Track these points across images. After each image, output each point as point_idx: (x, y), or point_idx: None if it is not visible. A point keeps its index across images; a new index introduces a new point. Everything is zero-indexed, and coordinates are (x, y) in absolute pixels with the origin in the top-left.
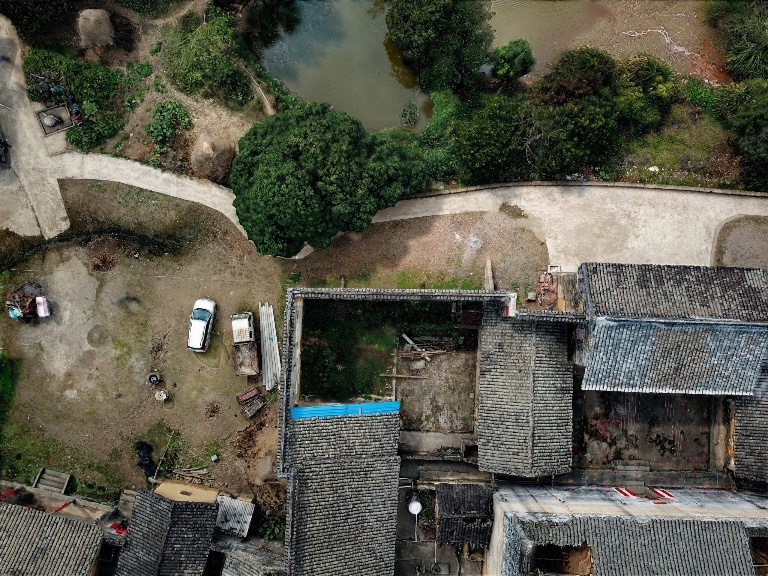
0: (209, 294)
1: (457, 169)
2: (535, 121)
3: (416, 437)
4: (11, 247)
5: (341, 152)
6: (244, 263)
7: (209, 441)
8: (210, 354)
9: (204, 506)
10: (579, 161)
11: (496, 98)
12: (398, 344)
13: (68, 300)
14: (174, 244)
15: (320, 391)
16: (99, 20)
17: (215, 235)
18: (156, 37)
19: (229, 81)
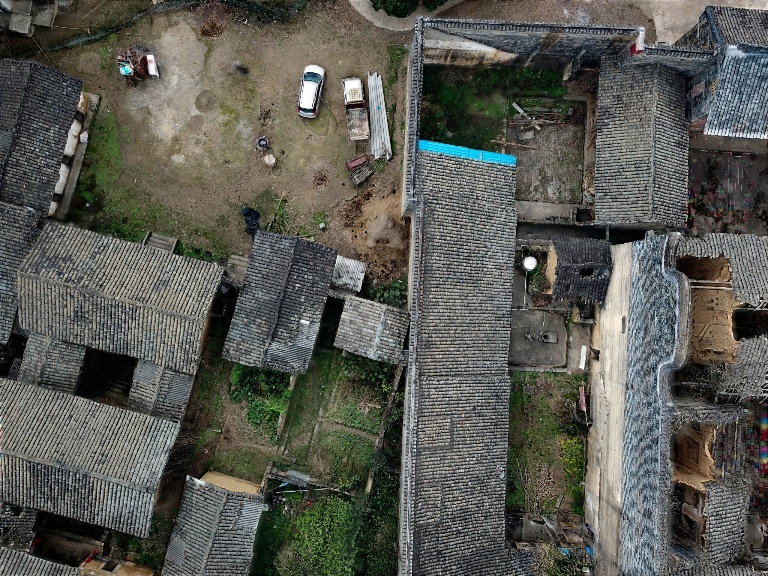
0: (318, 63)
1: None
2: None
3: (525, 206)
4: (119, 10)
5: None
6: (353, 33)
7: (317, 209)
8: (318, 122)
9: (324, 248)
10: None
11: None
12: (507, 115)
13: (176, 64)
14: (283, 12)
15: None
16: None
17: (324, 4)
18: None
19: None
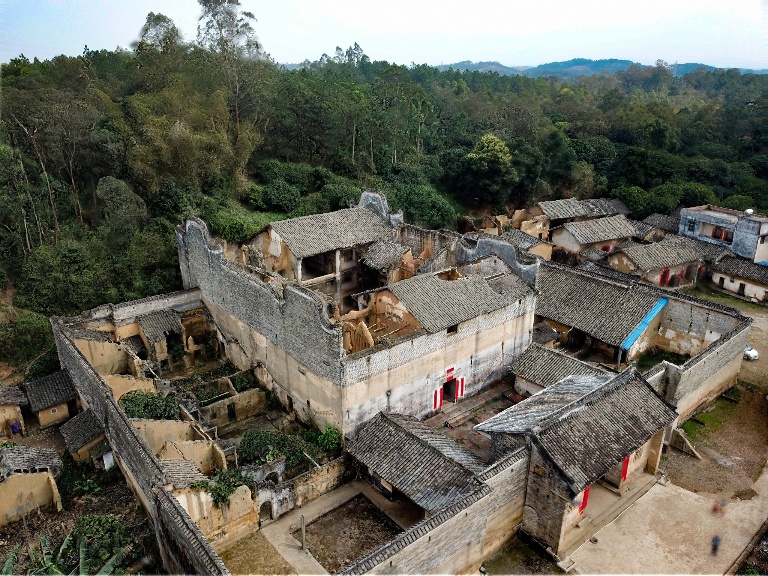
0: (760, 362)
1: None
2: None
3: None
4: None
5: None
6: None
7: None
8: None
9: None
10: None
11: None
12: None
13: None
14: None
15: None
16: None
17: None
18: None
19: None
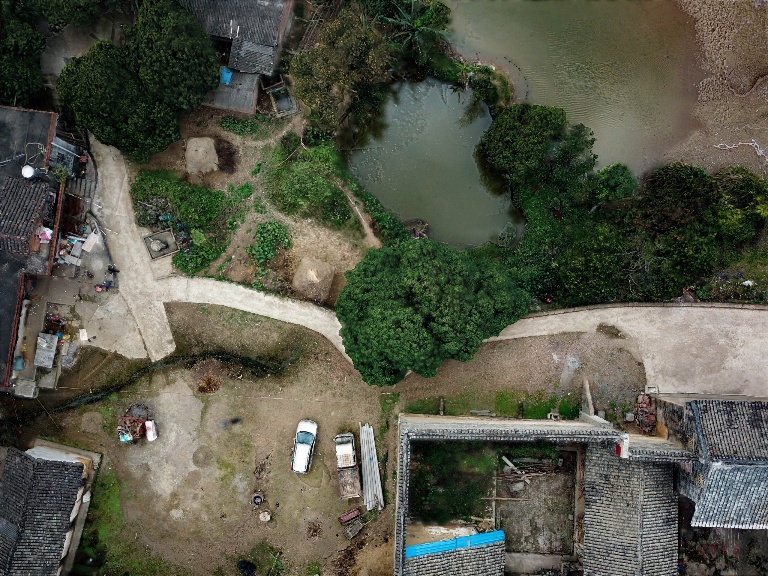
0: (310, 415)
1: (551, 287)
2: (640, 255)
3: (516, 559)
4: (119, 369)
5: (453, 293)
6: (344, 384)
7: (311, 560)
8: (312, 474)
9: None
10: (680, 288)
11: (600, 230)
12: (497, 465)
13: (174, 421)
14: (276, 366)
15: (421, 513)
16: (205, 150)
17: (316, 356)
18: (255, 158)
19: (326, 201)
